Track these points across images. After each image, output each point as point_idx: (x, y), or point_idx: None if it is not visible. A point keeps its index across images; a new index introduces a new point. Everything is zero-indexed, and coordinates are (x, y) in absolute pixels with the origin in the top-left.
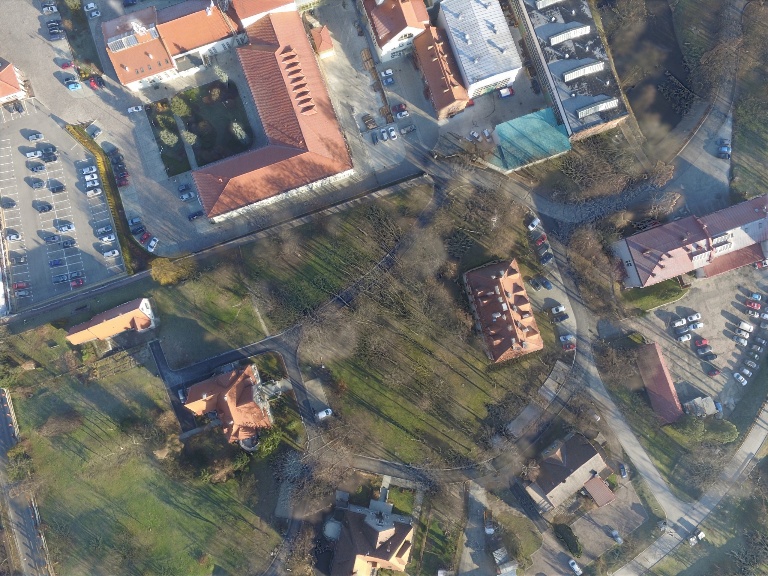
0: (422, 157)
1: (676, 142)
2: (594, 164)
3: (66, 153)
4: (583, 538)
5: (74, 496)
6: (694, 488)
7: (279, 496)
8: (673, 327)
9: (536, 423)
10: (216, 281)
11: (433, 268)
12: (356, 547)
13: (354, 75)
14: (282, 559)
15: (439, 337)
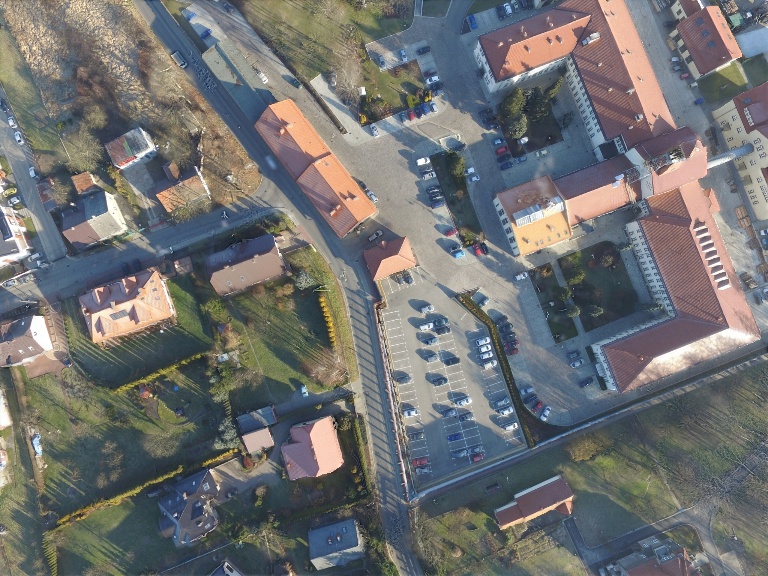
0: None
1: None
2: None
3: (456, 323)
4: None
5: None
6: None
7: None
8: None
9: None
10: (624, 454)
11: None
12: None
13: (729, 232)
14: None
15: None
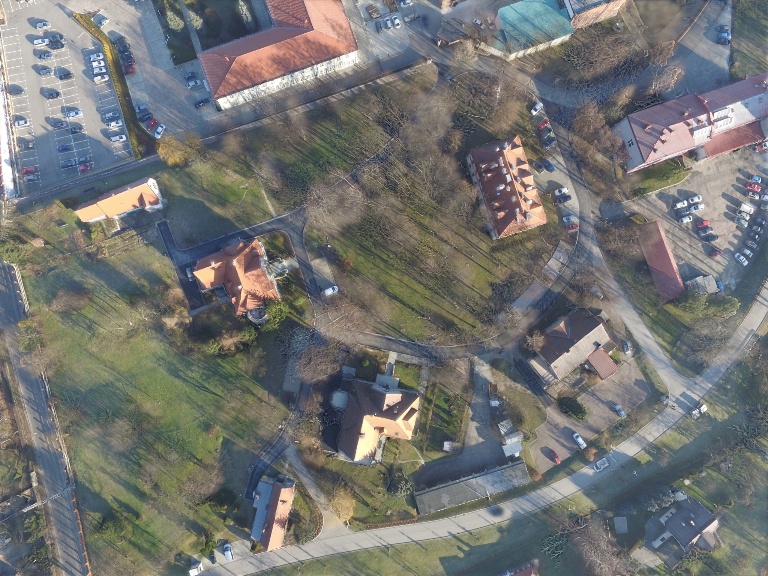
0: (426, 45)
1: (676, 29)
2: (596, 51)
3: (73, 41)
4: (587, 413)
5: (84, 370)
6: (696, 364)
7: (286, 371)
8: (674, 209)
9: (540, 302)
10: (223, 163)
11: (437, 144)
12: (363, 409)
13: None
14: (290, 432)
15: (444, 218)
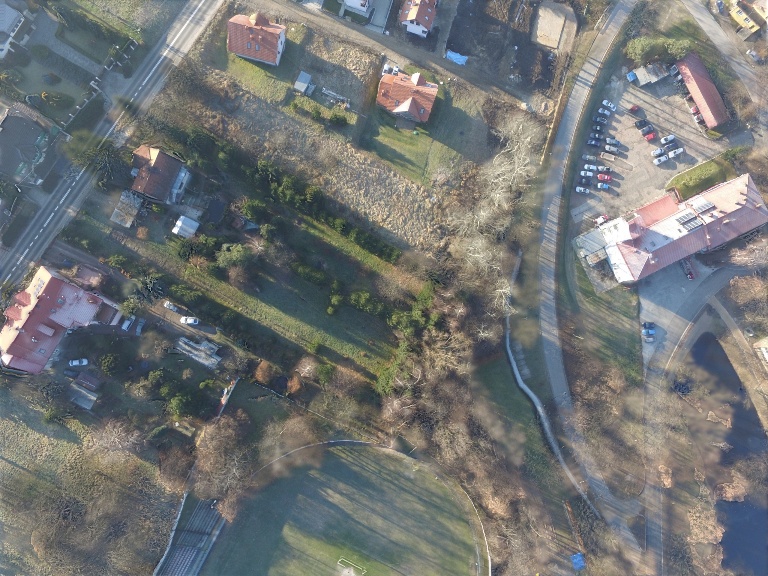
0: None
1: None
2: None
3: None
4: None
5: None
6: None
7: None
8: None
9: None
10: None
11: None
12: None
13: None
14: None
15: None
